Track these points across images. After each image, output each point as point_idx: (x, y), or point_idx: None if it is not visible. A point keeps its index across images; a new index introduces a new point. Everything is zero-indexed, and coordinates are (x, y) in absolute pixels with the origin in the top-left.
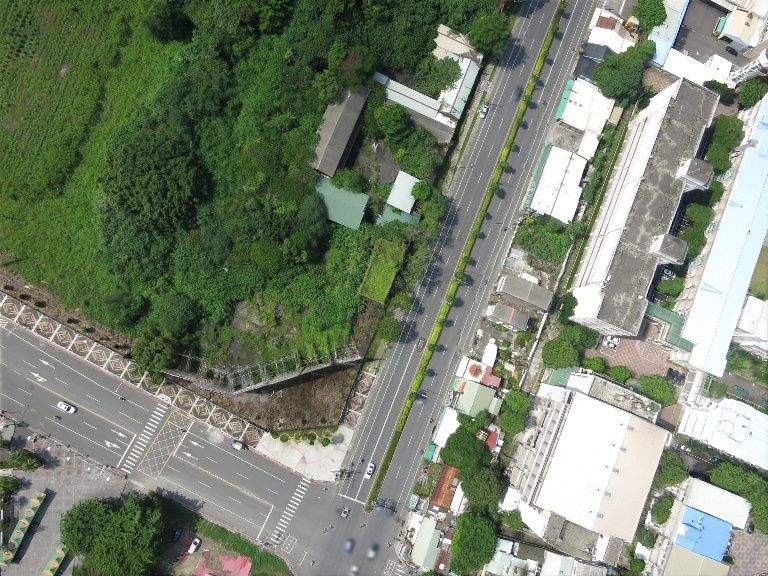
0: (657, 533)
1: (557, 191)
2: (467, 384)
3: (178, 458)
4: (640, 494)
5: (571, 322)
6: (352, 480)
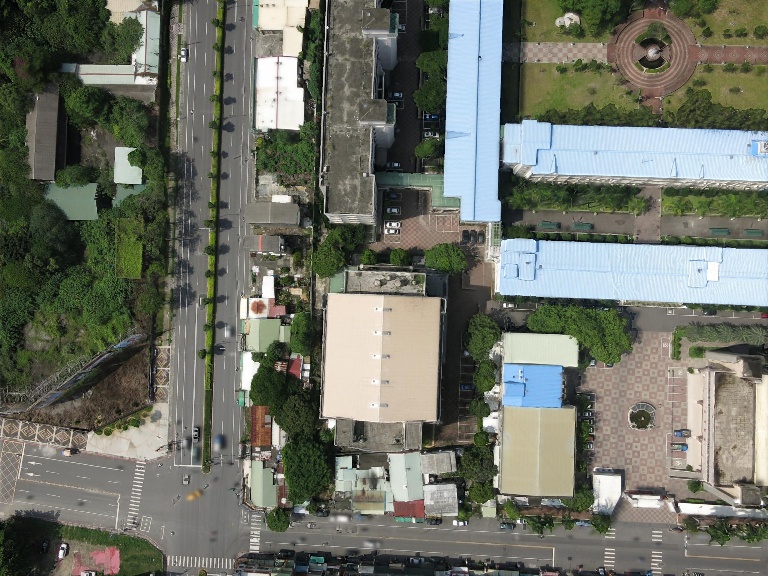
0: (499, 400)
1: (275, 102)
2: (250, 323)
3: (23, 480)
4: (427, 370)
5: (333, 225)
6: (182, 449)
